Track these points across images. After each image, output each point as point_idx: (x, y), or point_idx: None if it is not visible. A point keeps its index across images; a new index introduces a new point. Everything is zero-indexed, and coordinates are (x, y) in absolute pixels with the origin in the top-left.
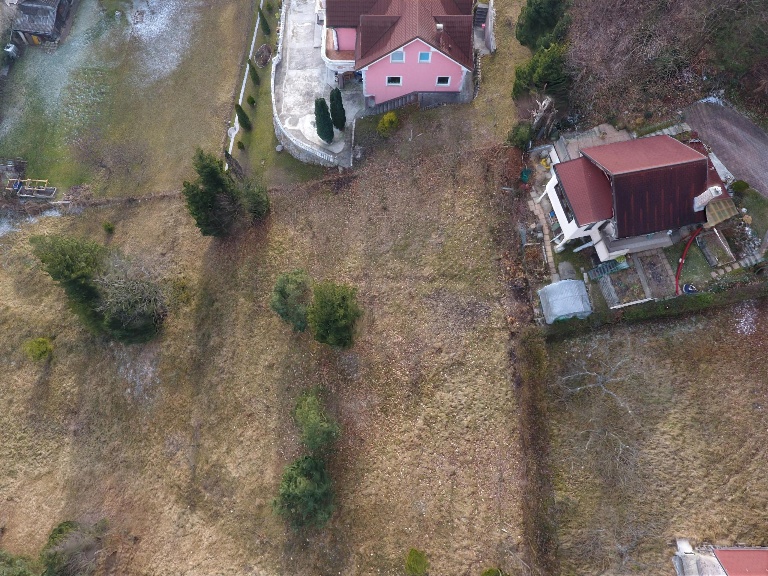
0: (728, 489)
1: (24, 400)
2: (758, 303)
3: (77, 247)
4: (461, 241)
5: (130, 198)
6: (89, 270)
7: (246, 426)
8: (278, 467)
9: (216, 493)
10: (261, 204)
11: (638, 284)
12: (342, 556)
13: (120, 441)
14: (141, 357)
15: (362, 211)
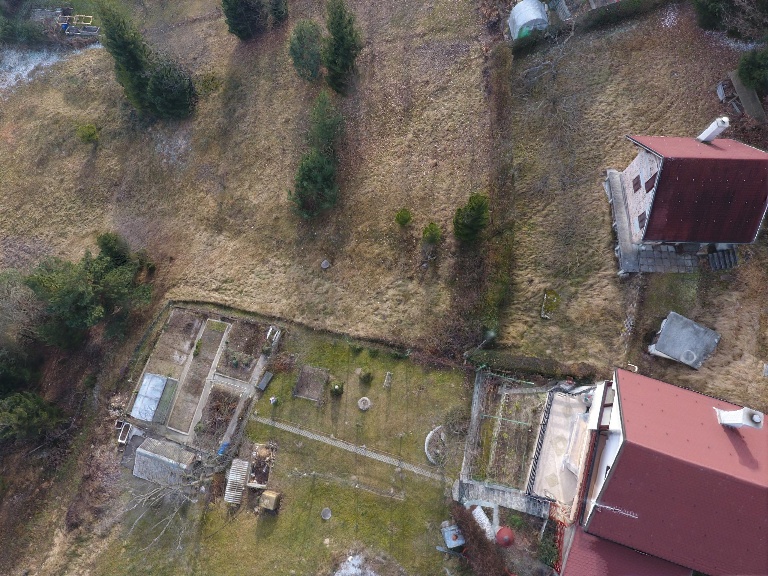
0: (648, 132)
1: (73, 179)
2: (680, 5)
3: (126, 27)
4: (448, 3)
5: (166, 24)
6: (138, 37)
7: (265, 167)
8: (292, 191)
9: (239, 219)
10: (281, 3)
11: (587, 2)
12: (344, 238)
13: (157, 199)
14: (175, 135)
15: (366, 1)
